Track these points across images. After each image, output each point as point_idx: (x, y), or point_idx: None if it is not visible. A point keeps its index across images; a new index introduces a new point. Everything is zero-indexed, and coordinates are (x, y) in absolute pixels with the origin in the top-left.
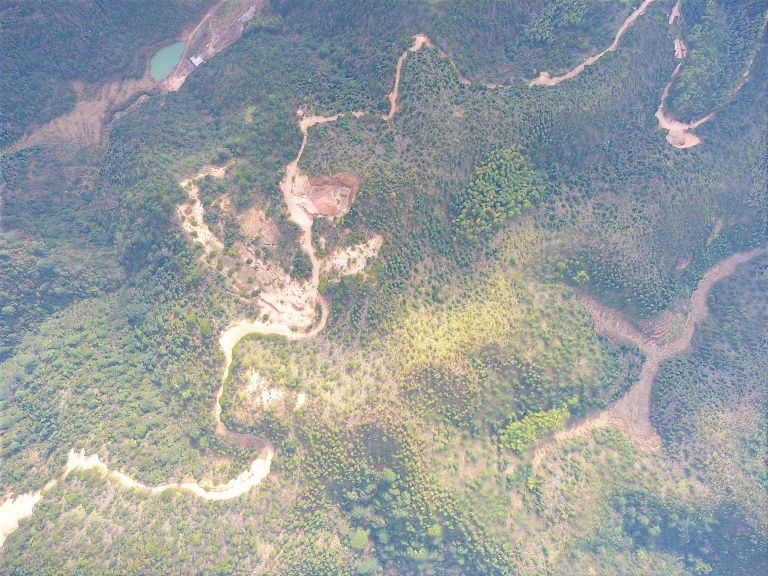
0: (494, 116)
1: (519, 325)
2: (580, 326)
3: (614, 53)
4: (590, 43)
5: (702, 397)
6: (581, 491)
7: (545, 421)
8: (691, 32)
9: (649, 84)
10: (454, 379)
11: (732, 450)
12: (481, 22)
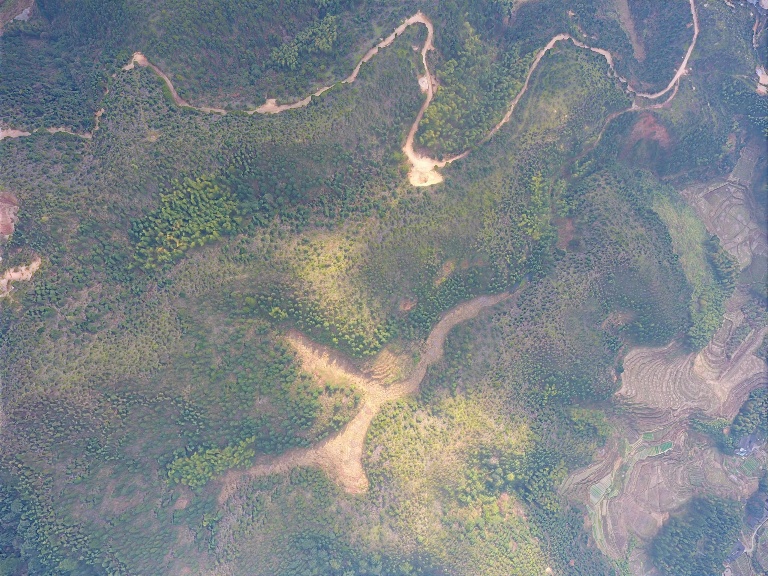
0: (189, 143)
1: (174, 361)
2: (273, 363)
3: (344, 85)
4: (332, 72)
5: (406, 443)
6: (253, 532)
7: (219, 459)
8: (445, 67)
9: (387, 118)
10: (82, 413)
11: (429, 500)
12: (213, 43)
